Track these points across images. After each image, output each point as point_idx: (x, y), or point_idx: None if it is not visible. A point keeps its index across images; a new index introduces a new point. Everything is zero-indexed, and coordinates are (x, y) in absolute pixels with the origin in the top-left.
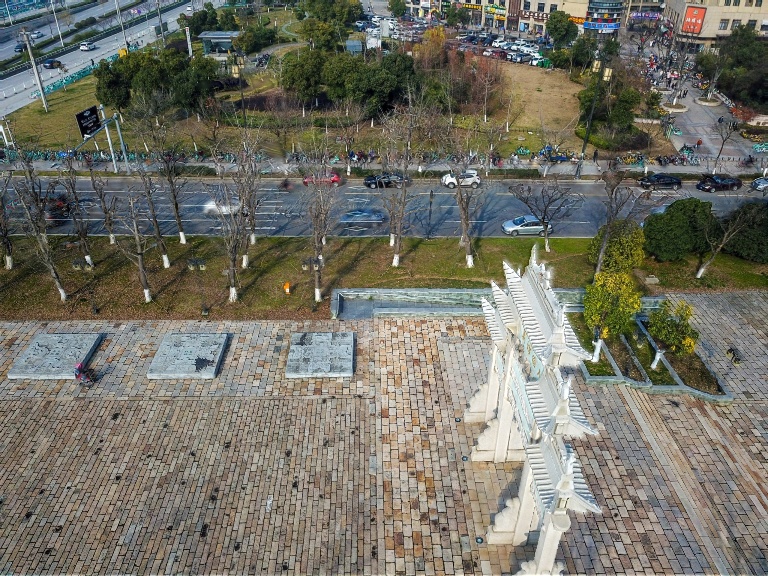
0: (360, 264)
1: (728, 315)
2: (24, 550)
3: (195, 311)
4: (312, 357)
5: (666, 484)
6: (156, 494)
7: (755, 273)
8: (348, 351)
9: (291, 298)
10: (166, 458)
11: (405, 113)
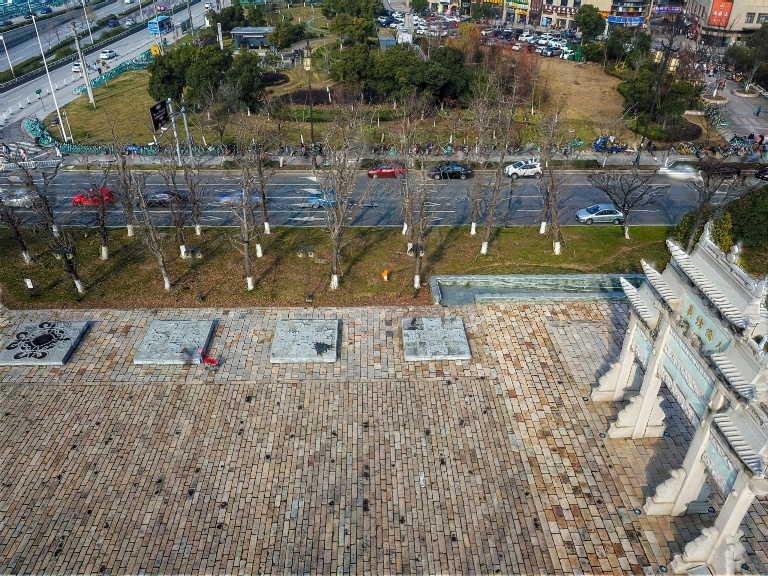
0: (448, 252)
1: None
2: (196, 525)
3: (299, 298)
4: (428, 341)
5: None
6: (309, 472)
7: None
8: (461, 335)
9: (390, 285)
10: (309, 438)
11: (508, 101)
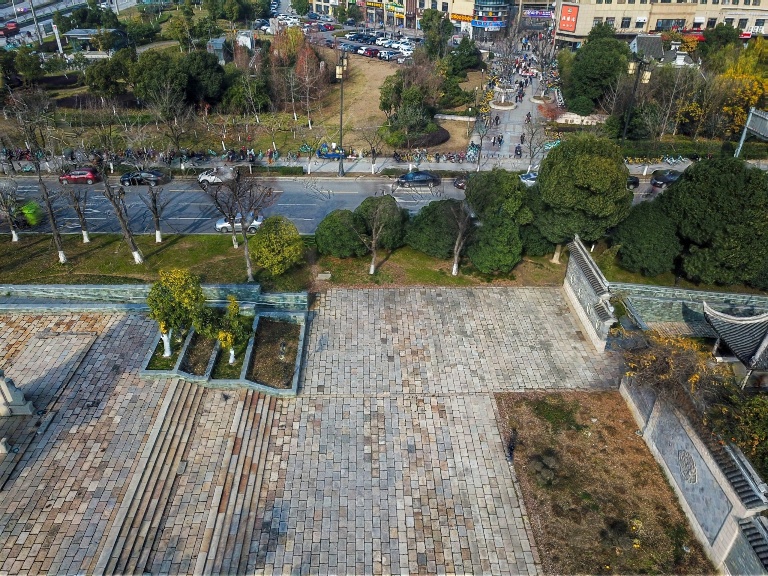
0: (31, 261)
1: (372, 310)
2: None
3: None
4: None
5: (127, 475)
6: None
7: (433, 269)
8: None
9: None
10: None
11: (14, 111)
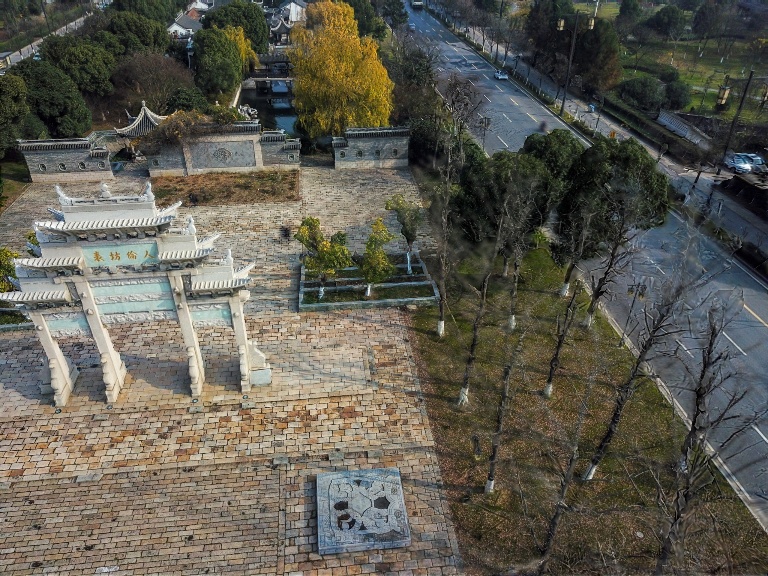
0: None
1: None
2: None
3: None
4: None
5: None
6: None
7: None
8: None
9: None
10: None
11: None
